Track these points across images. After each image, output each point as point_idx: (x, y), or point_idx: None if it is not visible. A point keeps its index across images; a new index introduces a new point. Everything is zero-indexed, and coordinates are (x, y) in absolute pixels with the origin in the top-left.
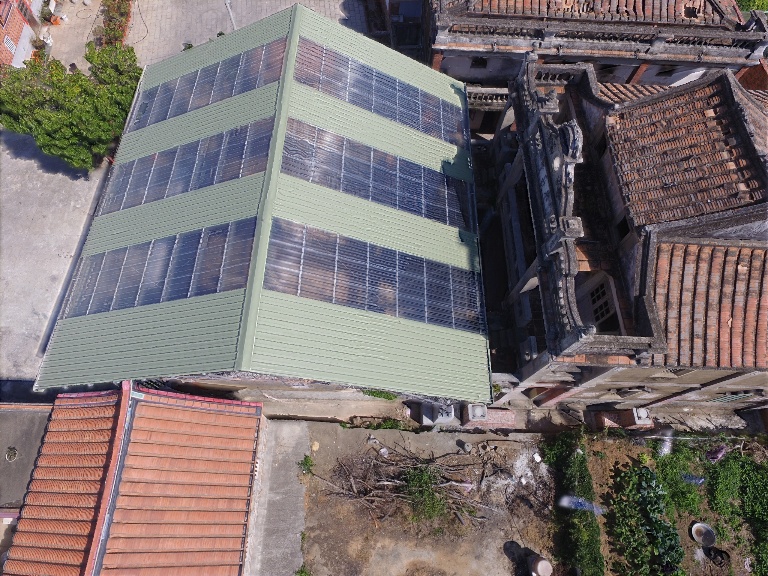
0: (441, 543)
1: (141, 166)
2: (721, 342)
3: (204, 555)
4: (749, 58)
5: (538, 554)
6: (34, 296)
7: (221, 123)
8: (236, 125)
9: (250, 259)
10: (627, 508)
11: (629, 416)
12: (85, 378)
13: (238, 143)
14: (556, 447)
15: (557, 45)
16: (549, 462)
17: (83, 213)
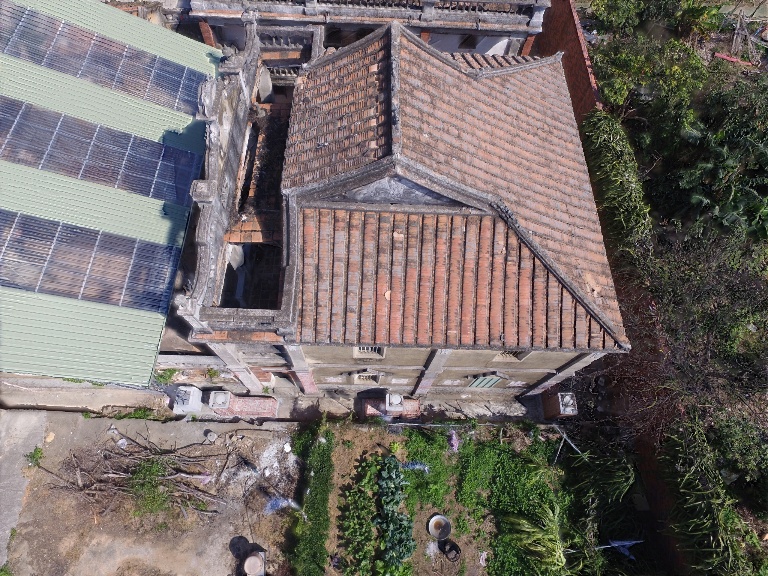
0: (162, 539)
1: None
2: (377, 316)
3: None
4: (530, 25)
5: (265, 550)
6: None
7: None
8: None
9: None
10: (360, 500)
11: (385, 403)
12: None
13: None
14: (303, 436)
15: (323, 11)
16: (296, 452)
17: None
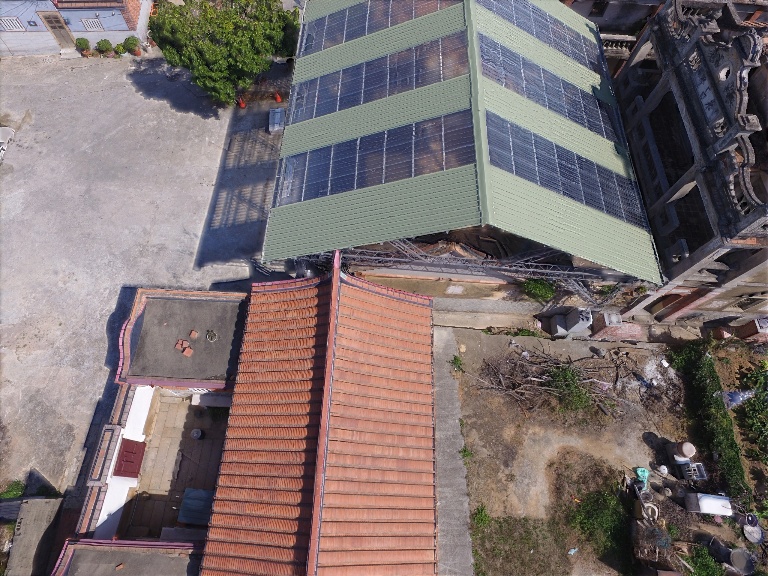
0: (586, 432)
1: (326, 82)
2: None
3: (404, 416)
4: None
5: None
6: (184, 218)
7: (407, 41)
8: (425, 41)
9: (474, 141)
10: (756, 403)
11: (750, 327)
12: (317, 248)
13: (431, 55)
14: (684, 352)
15: None
16: (677, 366)
17: (218, 148)
